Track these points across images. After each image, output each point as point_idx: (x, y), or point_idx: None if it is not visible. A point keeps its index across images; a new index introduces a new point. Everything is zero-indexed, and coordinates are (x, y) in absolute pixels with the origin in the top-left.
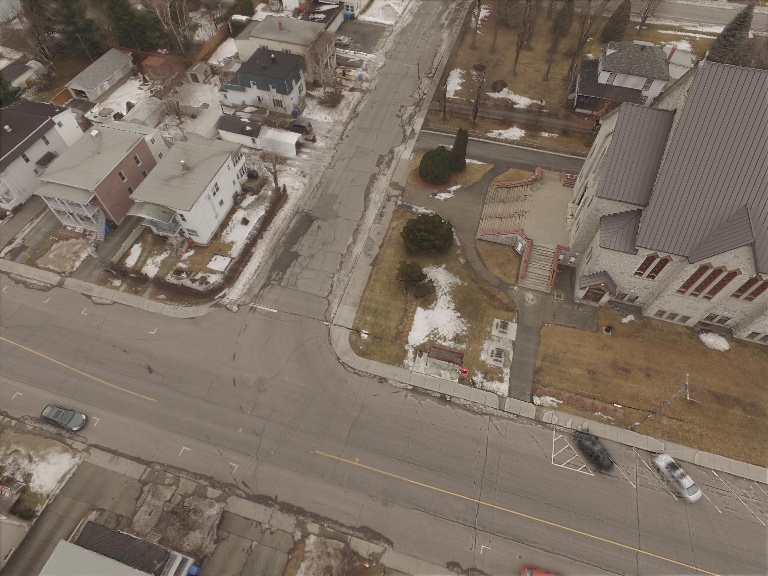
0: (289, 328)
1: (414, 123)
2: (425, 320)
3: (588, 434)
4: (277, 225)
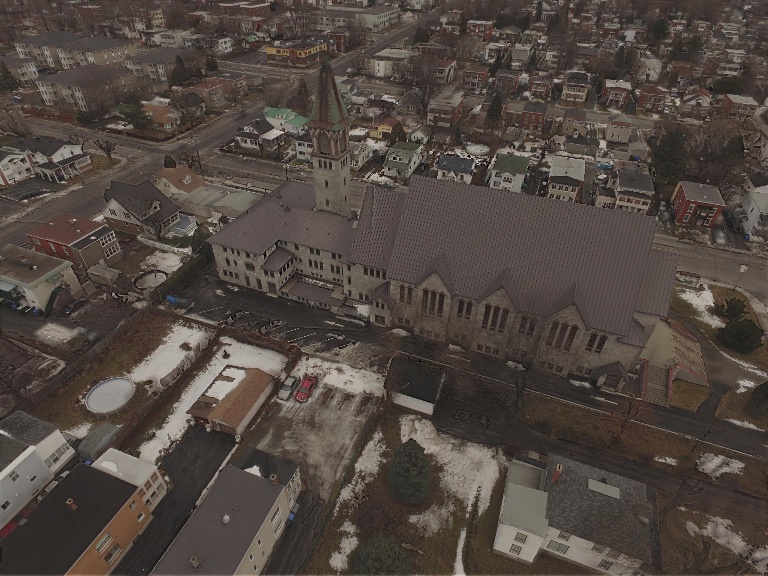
0: None
1: None
2: (707, 300)
3: None
4: None
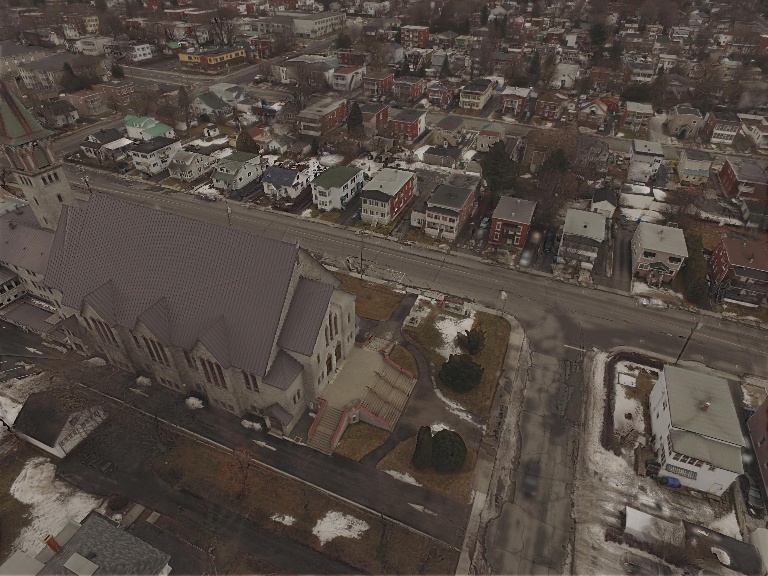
0: (552, 335)
1: (470, 572)
2: (463, 330)
3: (383, 280)
4: (597, 412)
